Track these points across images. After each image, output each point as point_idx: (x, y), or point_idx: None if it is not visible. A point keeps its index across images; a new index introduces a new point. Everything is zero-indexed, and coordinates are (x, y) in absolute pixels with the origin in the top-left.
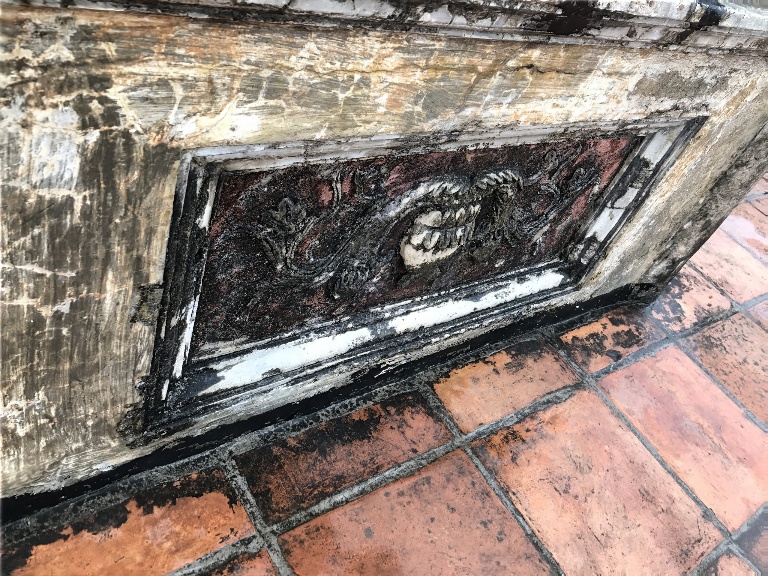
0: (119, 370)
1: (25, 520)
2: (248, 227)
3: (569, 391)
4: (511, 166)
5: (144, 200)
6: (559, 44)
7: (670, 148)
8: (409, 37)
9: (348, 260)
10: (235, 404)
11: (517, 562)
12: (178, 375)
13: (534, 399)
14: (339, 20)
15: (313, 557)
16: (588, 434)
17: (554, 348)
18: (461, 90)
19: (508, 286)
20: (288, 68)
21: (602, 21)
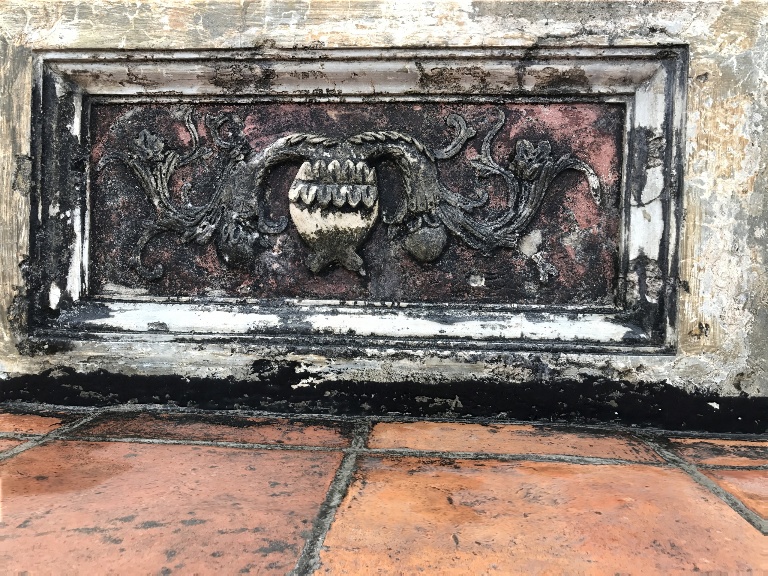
0: (7, 239)
1: None
2: (121, 154)
3: (620, 462)
4: (400, 130)
5: (14, 83)
6: None
7: (670, 103)
8: None
9: (228, 213)
10: (113, 341)
11: (266, 511)
12: (75, 297)
13: (532, 453)
14: None
15: (56, 451)
16: (603, 486)
17: (640, 439)
18: (236, 13)
19: (509, 320)
20: (90, 0)
21: None
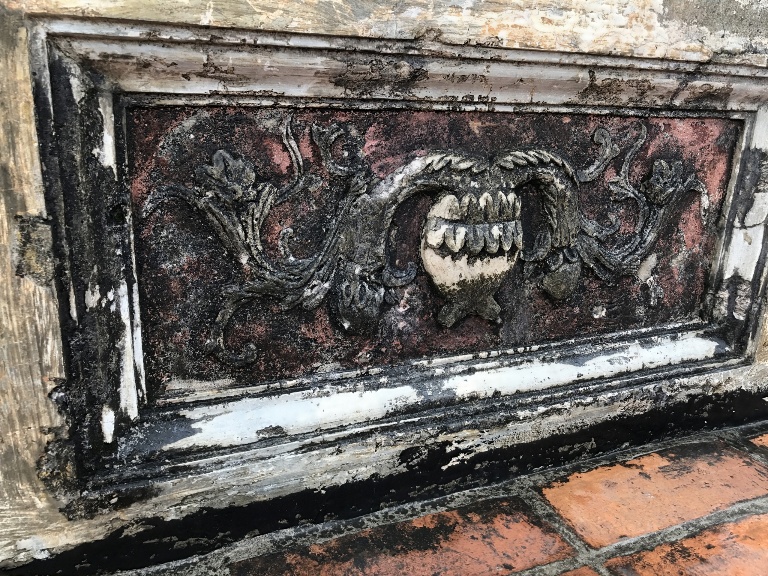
0: (18, 359)
1: None
2: (182, 189)
3: None
4: (546, 148)
5: None
6: None
7: None
8: None
9: (345, 266)
10: (218, 470)
11: None
12: (132, 414)
13: (715, 508)
14: None
15: None
16: None
17: (741, 451)
18: None
19: (627, 350)
20: None
21: None
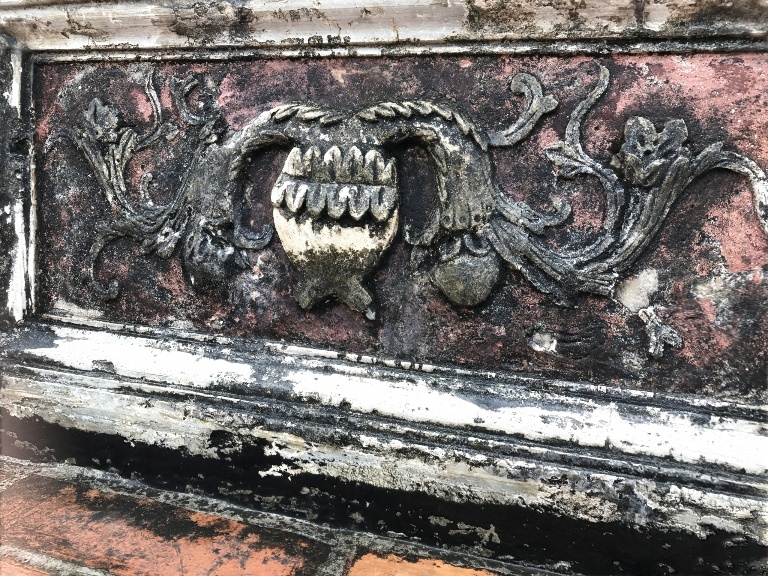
0: None
1: None
2: (70, 131)
3: None
4: (437, 100)
5: None
6: None
7: None
8: None
9: None
10: (49, 382)
11: None
12: (18, 317)
13: None
14: None
15: None
16: None
17: None
18: None
19: (589, 413)
20: None
21: None
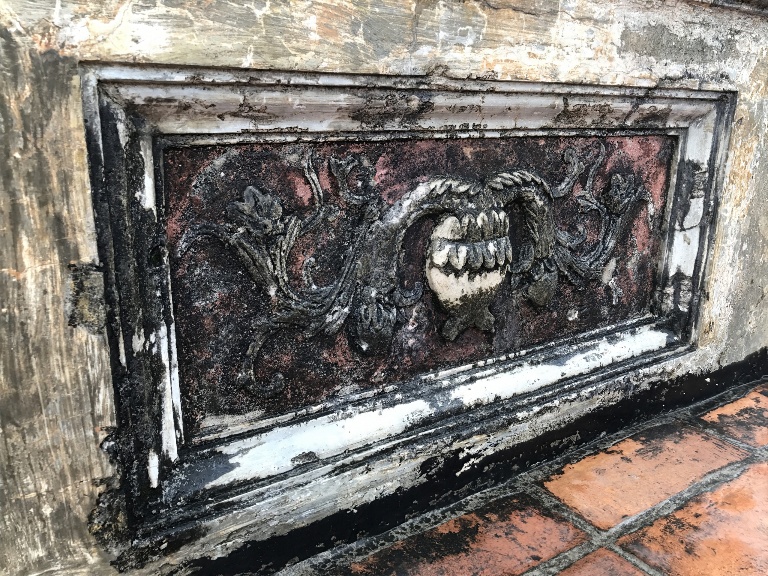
0: (70, 411)
1: None
2: (214, 227)
3: (739, 467)
4: (526, 168)
5: (46, 129)
6: None
7: (714, 141)
8: None
9: (362, 290)
10: (260, 502)
11: None
12: (173, 456)
13: (691, 481)
14: None
15: None
16: None
17: (697, 428)
18: (404, 22)
19: (597, 347)
20: None
21: None
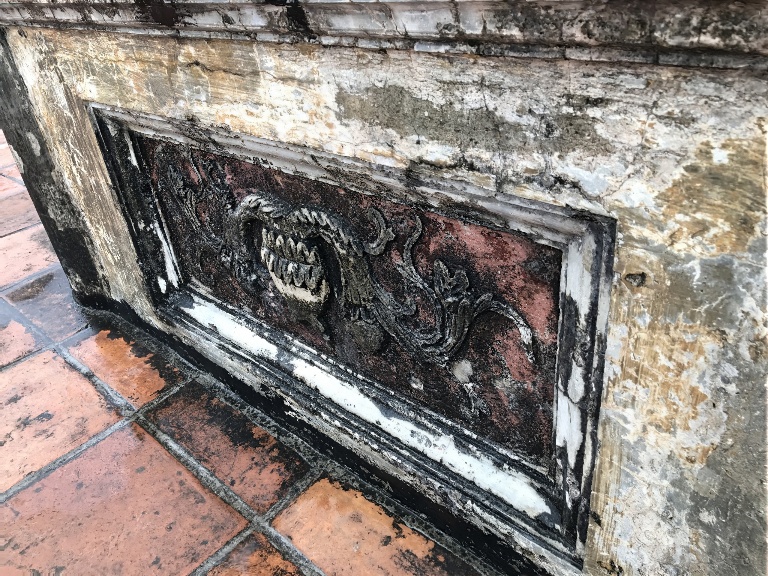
0: None
1: (137, 329)
2: None
3: None
4: (332, 211)
5: None
6: (200, 39)
7: None
8: (116, 36)
9: None
10: (192, 331)
11: None
12: (175, 285)
13: None
14: (82, 25)
15: (119, 443)
16: None
17: None
18: None
19: (439, 437)
20: (91, 57)
21: (182, 7)
